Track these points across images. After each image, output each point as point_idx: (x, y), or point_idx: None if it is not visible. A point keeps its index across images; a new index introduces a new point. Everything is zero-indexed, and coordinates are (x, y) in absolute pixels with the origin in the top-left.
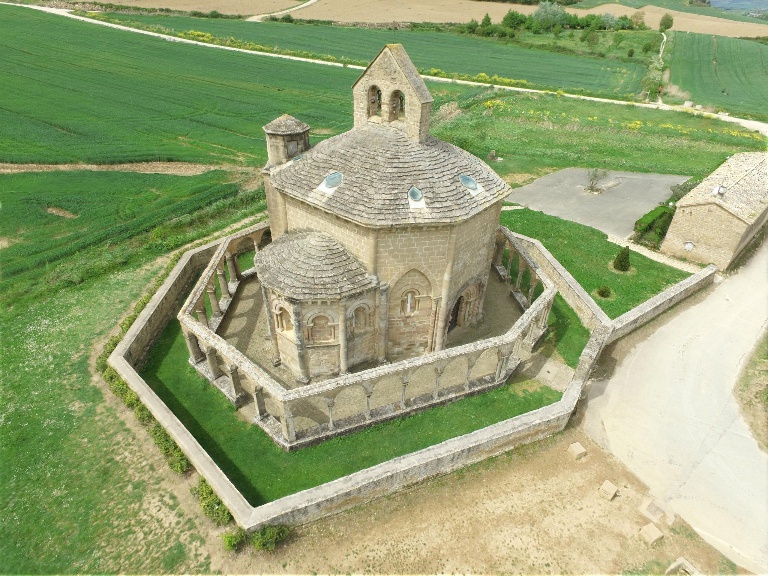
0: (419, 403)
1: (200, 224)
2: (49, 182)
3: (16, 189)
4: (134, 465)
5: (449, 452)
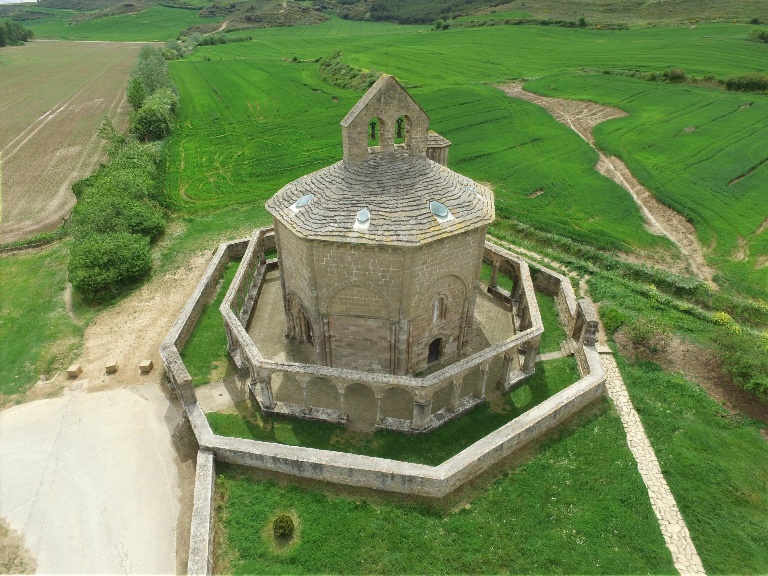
0: (246, 304)
1: (523, 237)
2: (590, 185)
3: (572, 180)
4: None
5: (194, 292)
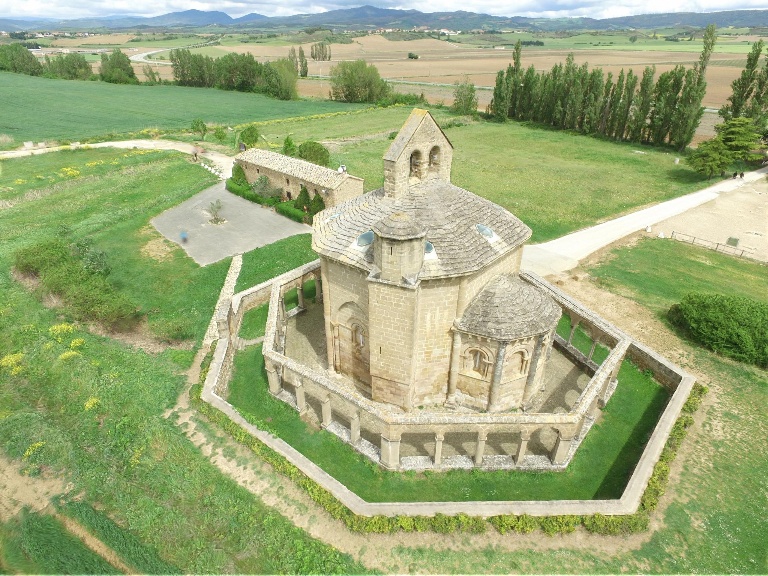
0: None
1: None
2: None
3: None
4: (706, 453)
5: (588, 309)
